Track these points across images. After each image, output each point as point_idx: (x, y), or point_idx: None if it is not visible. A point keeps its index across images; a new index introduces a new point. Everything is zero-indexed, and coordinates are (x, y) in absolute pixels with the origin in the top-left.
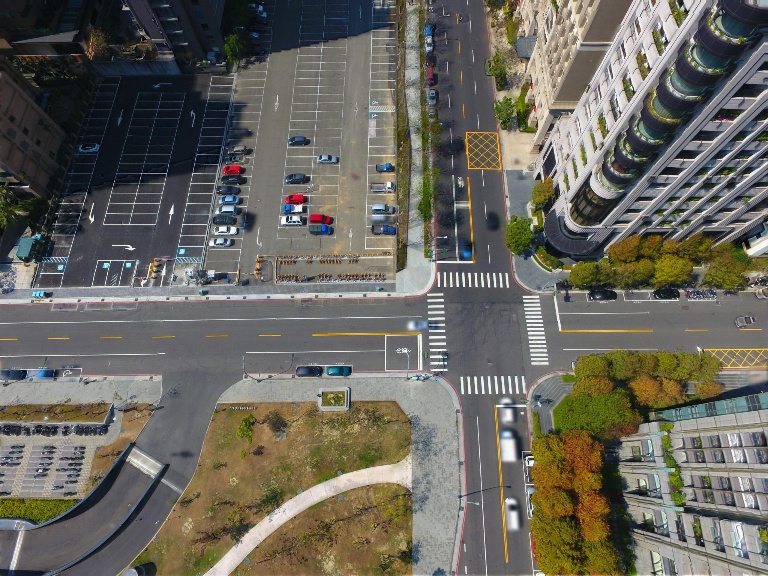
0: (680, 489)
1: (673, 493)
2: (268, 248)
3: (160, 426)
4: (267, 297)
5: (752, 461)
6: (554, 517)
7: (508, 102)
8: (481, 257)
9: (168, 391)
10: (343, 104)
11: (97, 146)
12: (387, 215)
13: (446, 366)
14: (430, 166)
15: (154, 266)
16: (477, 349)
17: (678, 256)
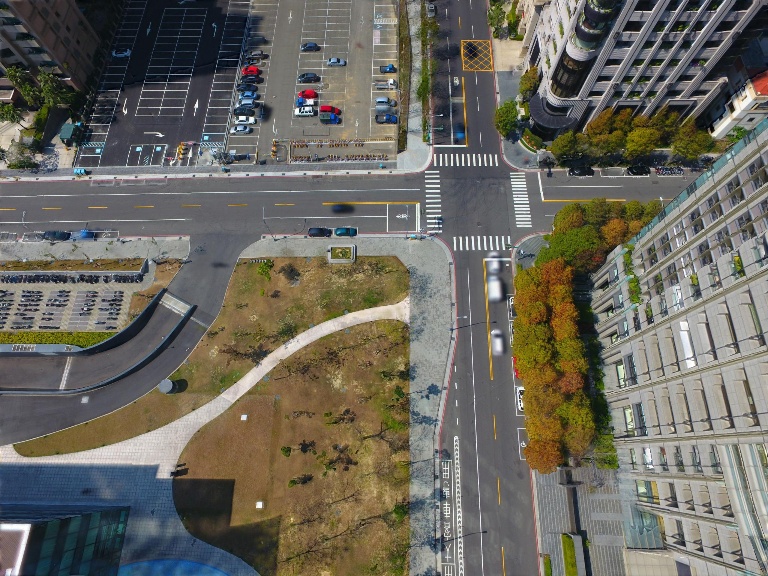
0: (638, 296)
1: (631, 295)
2: (283, 135)
3: (189, 276)
4: (282, 174)
5: (690, 237)
6: (531, 323)
7: (499, 8)
8: (473, 142)
9: (195, 249)
10: (350, 17)
11: (129, 51)
12: (389, 106)
13: (441, 228)
14: (429, 68)
15: (181, 149)
16: (469, 215)
17: (647, 128)
